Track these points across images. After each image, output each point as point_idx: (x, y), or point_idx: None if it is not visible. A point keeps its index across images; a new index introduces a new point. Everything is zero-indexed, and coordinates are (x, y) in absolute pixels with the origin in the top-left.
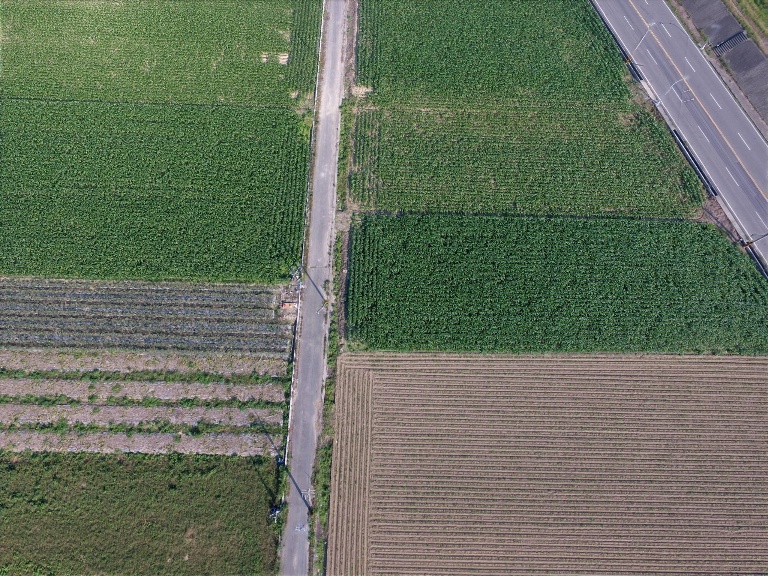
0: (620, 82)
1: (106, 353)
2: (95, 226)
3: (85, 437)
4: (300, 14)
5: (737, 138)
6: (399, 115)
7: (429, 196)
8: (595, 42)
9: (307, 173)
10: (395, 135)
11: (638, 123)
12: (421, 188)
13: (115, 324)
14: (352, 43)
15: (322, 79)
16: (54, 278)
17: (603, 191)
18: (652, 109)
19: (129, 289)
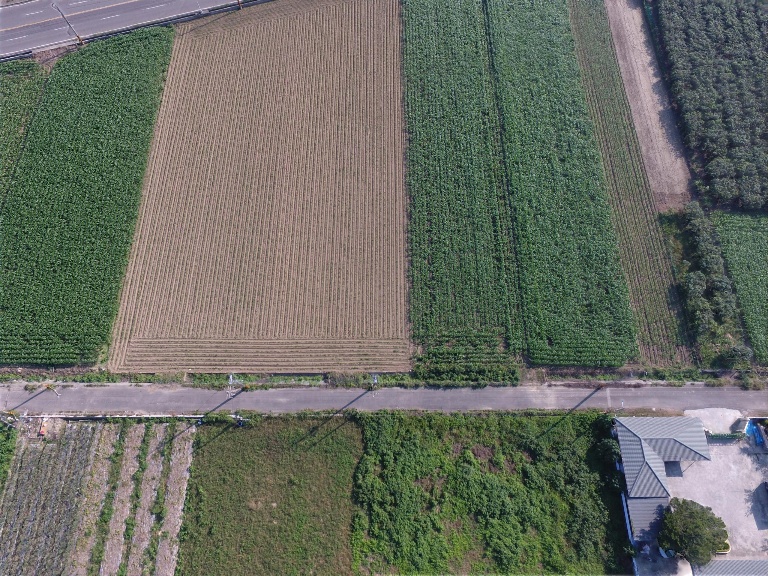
0: None
1: None
2: None
3: None
4: None
5: None
6: None
7: None
8: None
9: None
10: None
11: None
12: None
13: None
14: None
15: None
16: None
17: (1, 132)
18: None
19: None
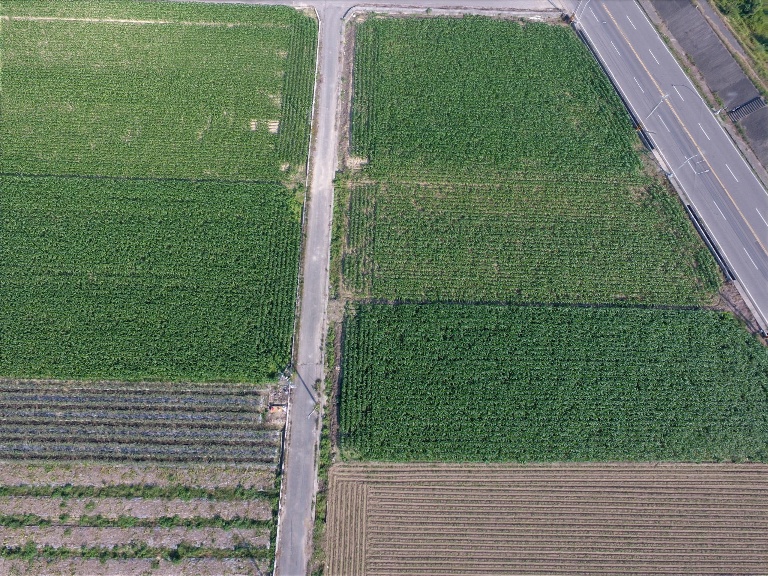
0: (630, 151)
1: (79, 465)
2: (70, 319)
3: (55, 564)
4: (291, 77)
5: (755, 215)
6: (396, 190)
7: (428, 282)
8: (603, 107)
9: (298, 257)
10: (392, 213)
11: (650, 197)
12: (419, 273)
13: (90, 431)
14: (346, 108)
15: (314, 149)
16: (25, 378)
17: (613, 275)
18: (664, 182)
19: (105, 390)
